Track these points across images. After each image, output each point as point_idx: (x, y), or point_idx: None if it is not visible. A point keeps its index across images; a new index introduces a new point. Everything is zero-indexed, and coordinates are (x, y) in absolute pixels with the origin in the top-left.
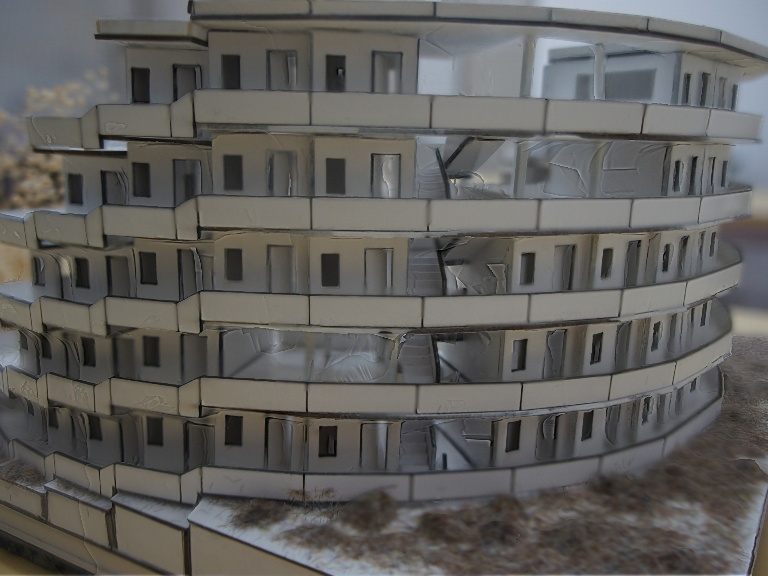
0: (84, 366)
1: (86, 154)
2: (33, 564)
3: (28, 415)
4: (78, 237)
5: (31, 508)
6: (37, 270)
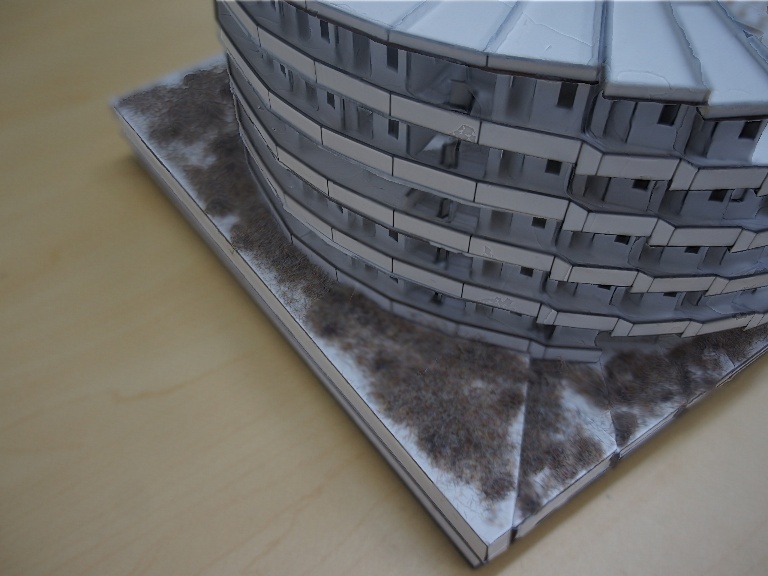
0: None
1: None
2: None
3: None
4: None
5: None
6: None
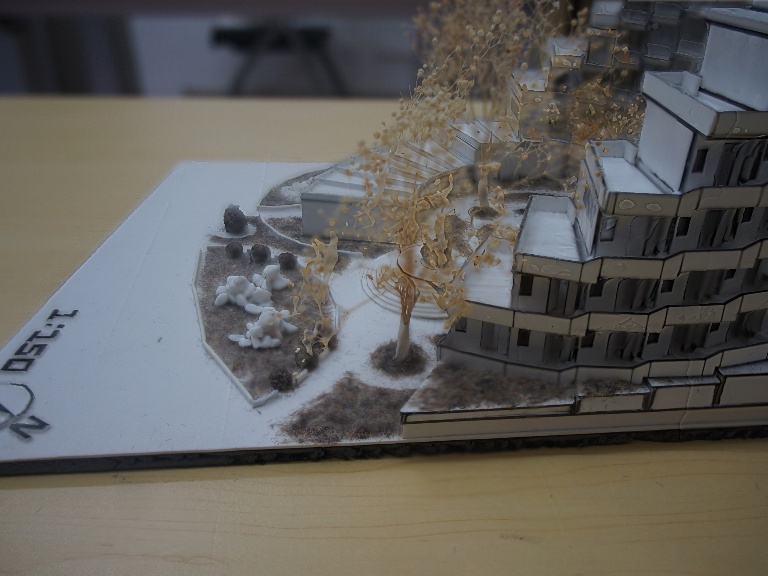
0: (661, 293)
1: (762, 138)
2: (608, 445)
3: (517, 348)
4: (747, 203)
5: (628, 407)
6: (601, 229)
